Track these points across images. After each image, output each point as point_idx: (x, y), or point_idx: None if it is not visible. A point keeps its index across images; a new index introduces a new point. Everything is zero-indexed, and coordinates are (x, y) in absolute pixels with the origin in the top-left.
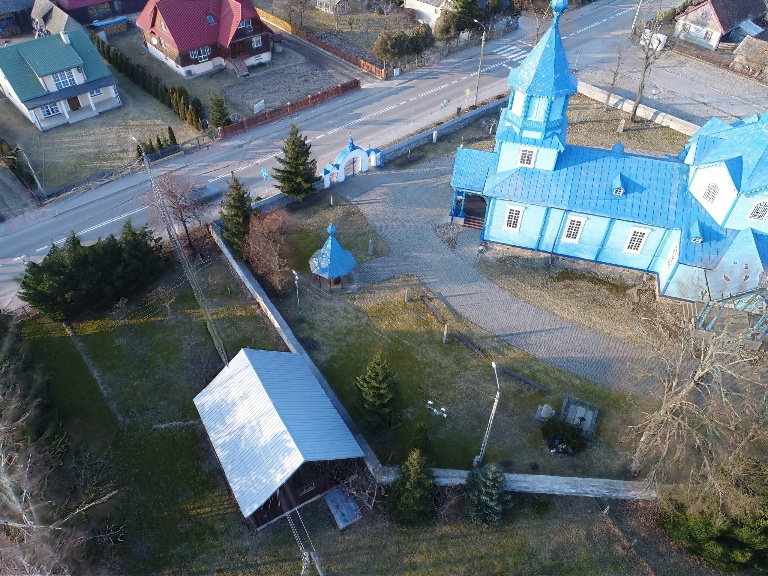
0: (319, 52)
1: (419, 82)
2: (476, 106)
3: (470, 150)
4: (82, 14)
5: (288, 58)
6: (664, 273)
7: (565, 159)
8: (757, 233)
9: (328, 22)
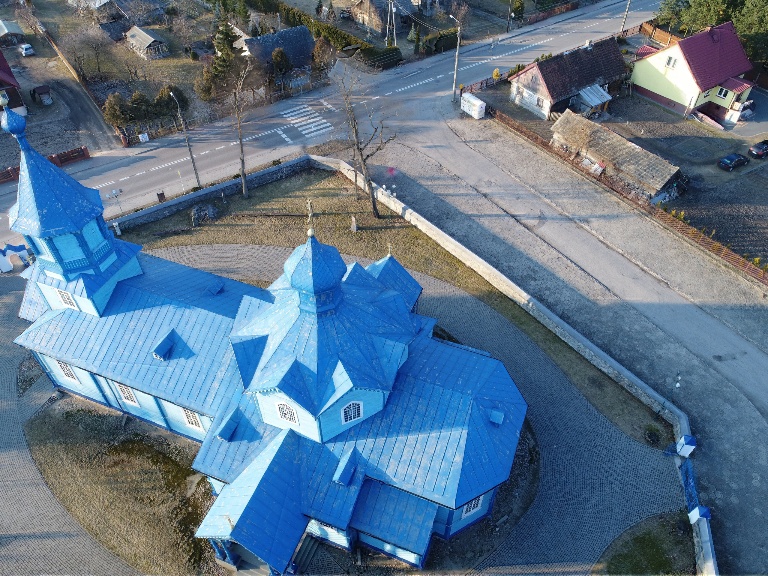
0: (90, 106)
1: (165, 151)
2: (198, 188)
3: None
4: None
5: (49, 113)
6: None
7: (118, 303)
8: (301, 436)
9: None
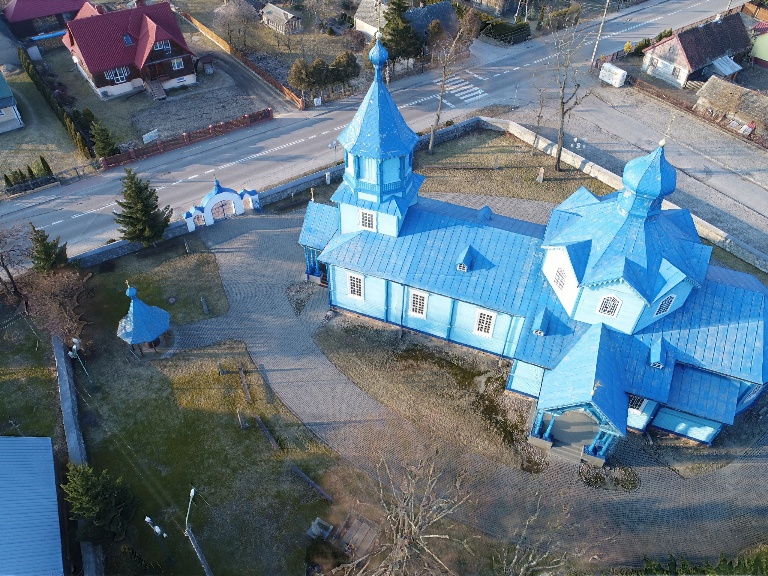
0: (250, 75)
1: (339, 114)
2: None
3: (321, 205)
4: (27, 26)
5: (215, 81)
6: None
7: (412, 224)
8: (611, 329)
9: (274, 42)
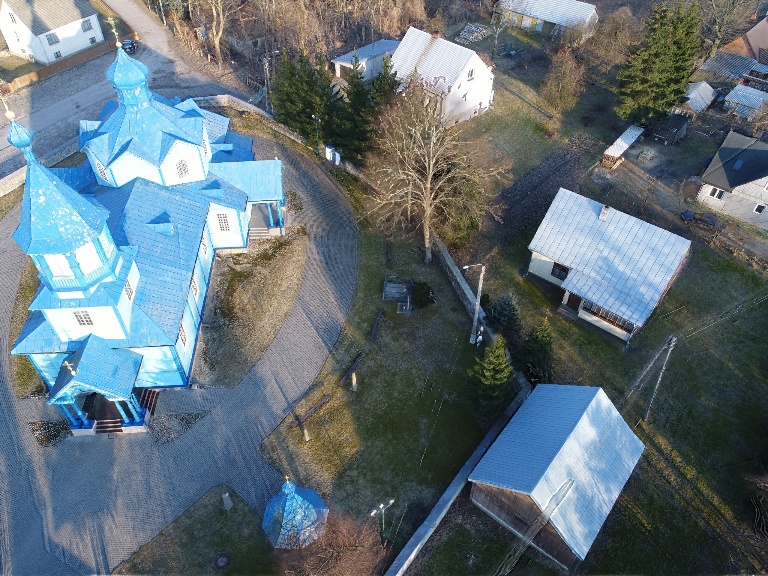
0: None
1: None
2: None
3: (80, 365)
4: None
5: None
6: (224, 240)
7: None
8: None
9: None
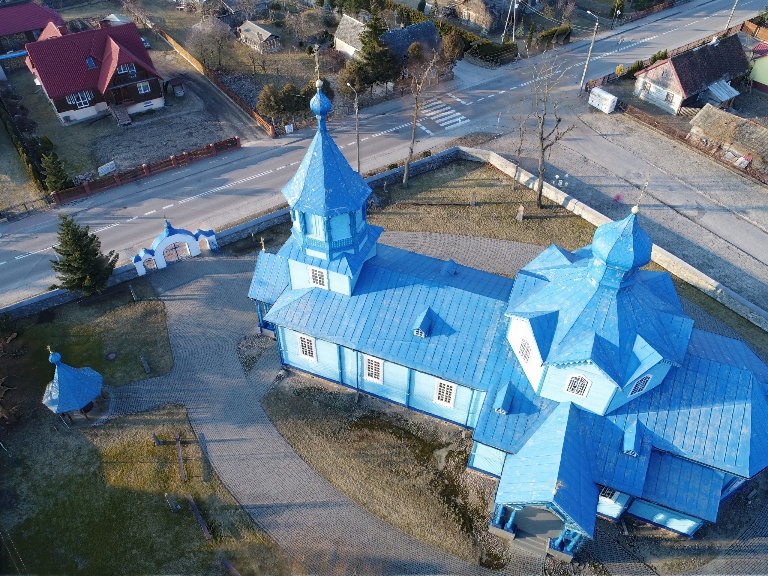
0: (222, 98)
1: None
2: None
3: (273, 256)
4: None
5: (184, 104)
6: None
7: (368, 282)
8: (581, 409)
9: (251, 62)
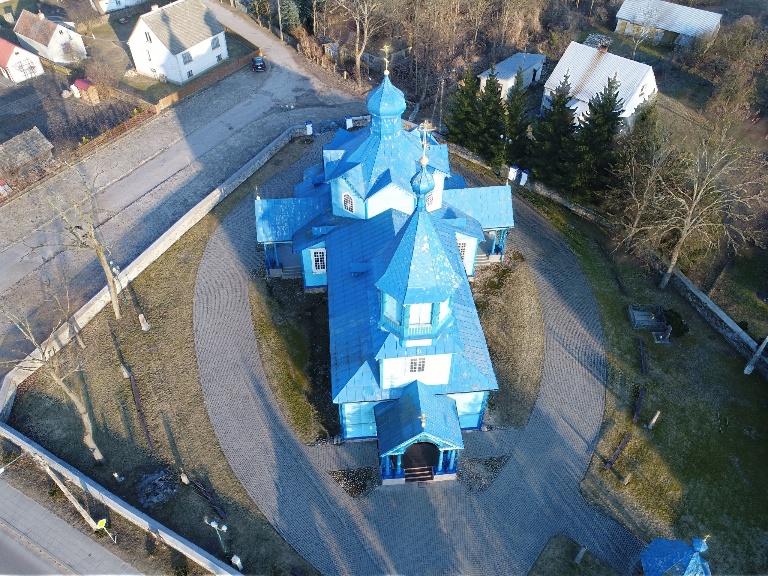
0: None
1: None
2: None
3: None
4: None
5: None
6: None
7: None
8: None
9: None
